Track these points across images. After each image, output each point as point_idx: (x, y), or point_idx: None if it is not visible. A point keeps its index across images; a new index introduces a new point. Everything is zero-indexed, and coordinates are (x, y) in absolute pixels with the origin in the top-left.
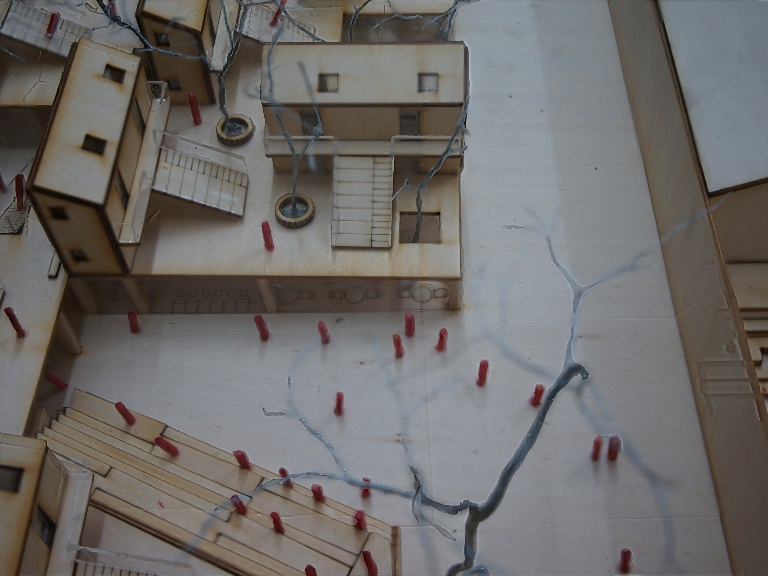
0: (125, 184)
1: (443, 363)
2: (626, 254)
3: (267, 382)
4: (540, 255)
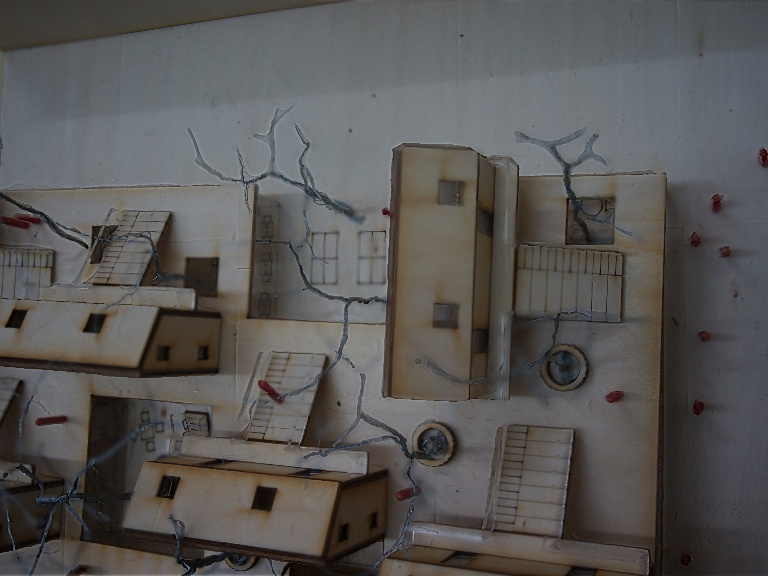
0: (567, 571)
1: (737, 204)
2: (586, 5)
3: (762, 402)
4: (585, 98)
